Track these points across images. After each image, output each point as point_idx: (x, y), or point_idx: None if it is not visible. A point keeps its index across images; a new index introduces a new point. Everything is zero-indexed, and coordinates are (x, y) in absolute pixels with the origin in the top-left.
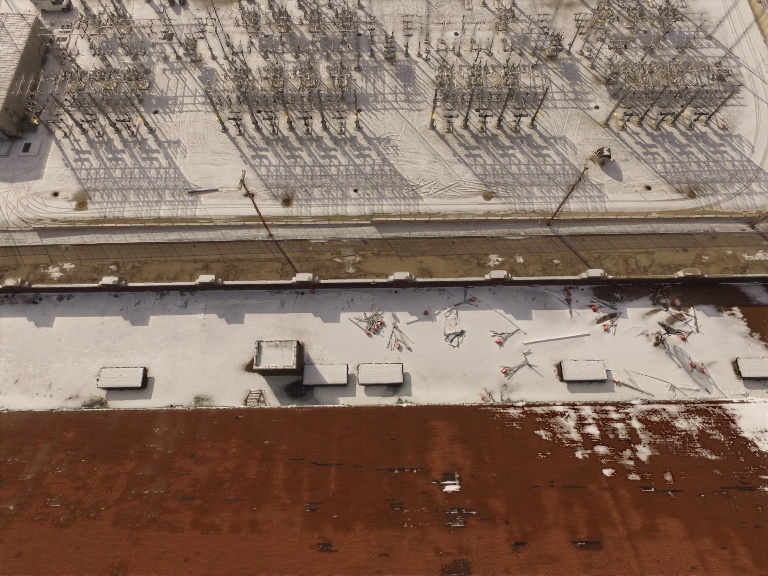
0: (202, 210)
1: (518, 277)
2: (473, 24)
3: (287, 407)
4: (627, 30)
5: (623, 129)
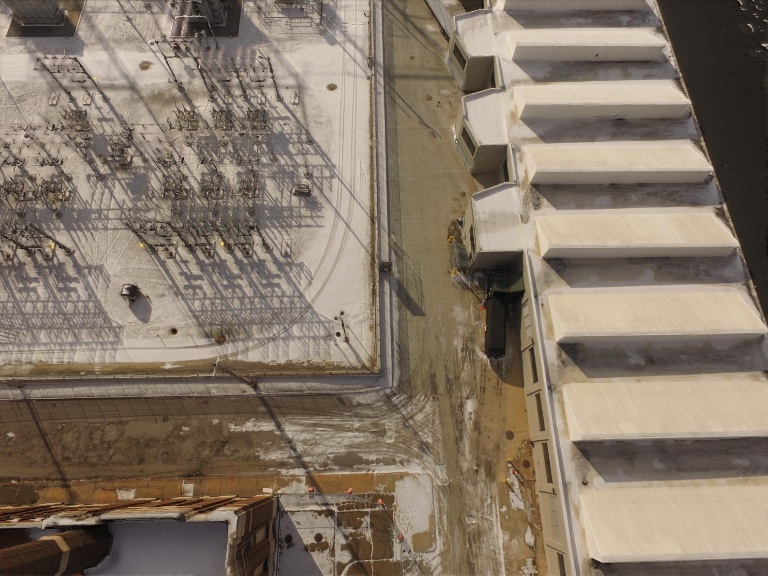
0: None
1: None
2: None
3: None
4: (222, 132)
5: (171, 256)
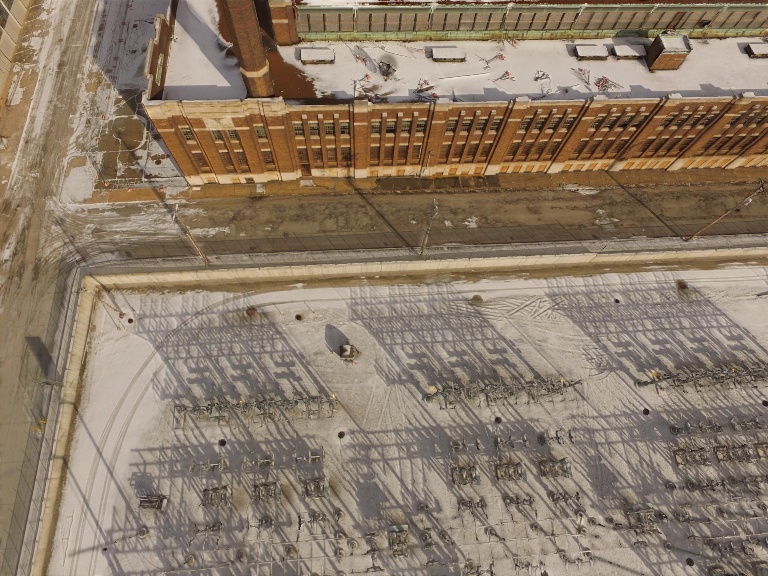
0: (760, 274)
1: (504, 102)
2: (533, 567)
3: (660, 4)
4: None
5: None
